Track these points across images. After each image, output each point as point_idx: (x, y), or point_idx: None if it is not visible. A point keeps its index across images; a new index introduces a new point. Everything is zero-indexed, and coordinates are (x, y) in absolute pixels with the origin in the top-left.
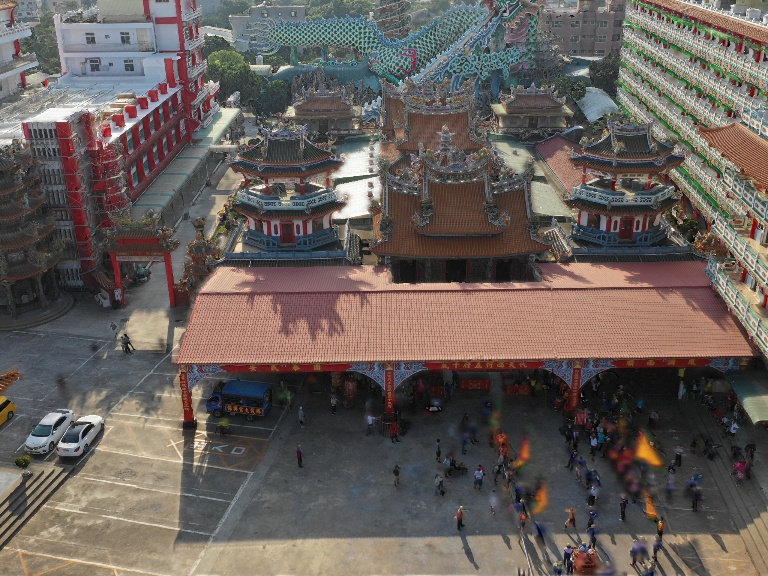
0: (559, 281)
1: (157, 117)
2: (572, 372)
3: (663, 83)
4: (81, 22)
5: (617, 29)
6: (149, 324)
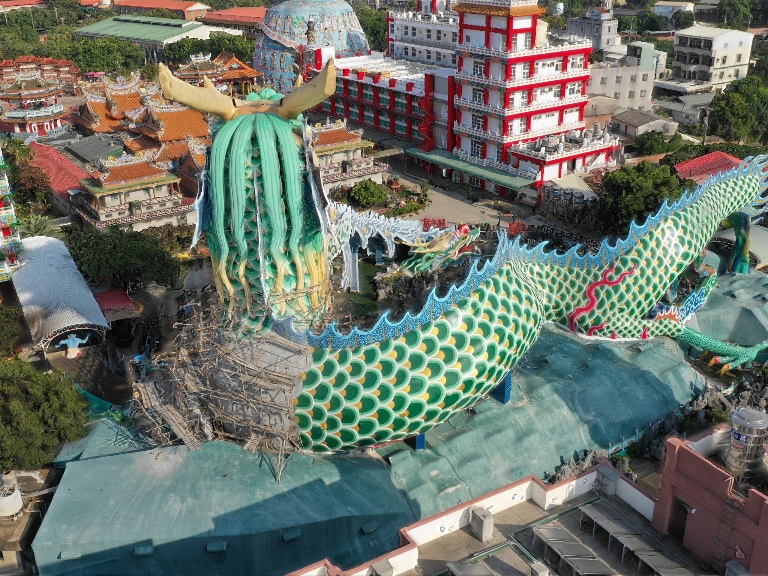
0: None
1: None
2: None
3: None
4: None
5: None
6: None
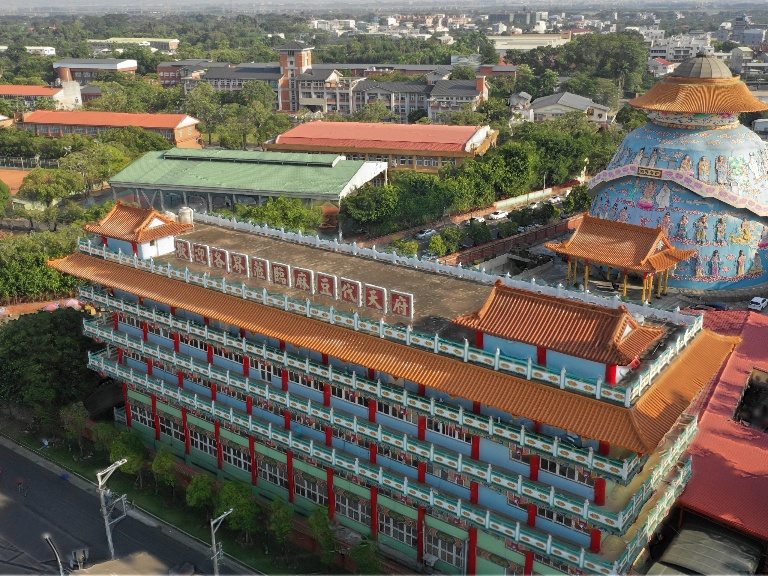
0: (729, 424)
1: None
2: None
3: None
4: None
5: None
6: None
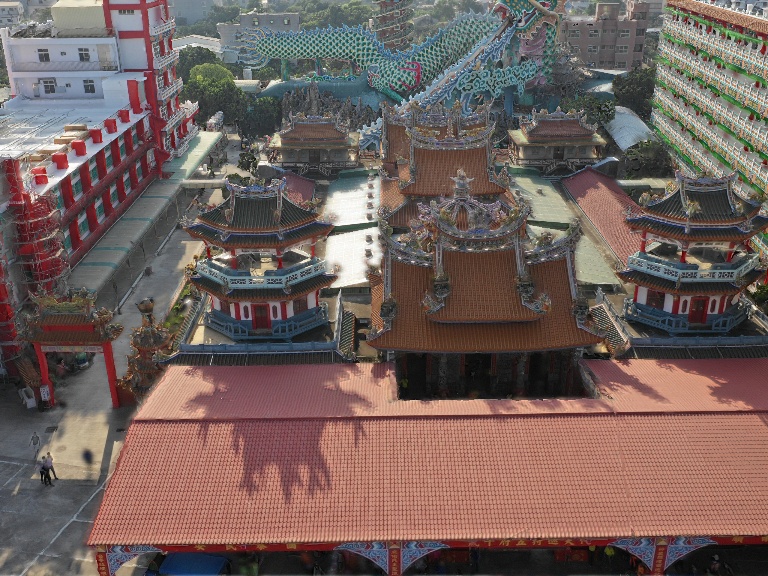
0: (622, 397)
1: (115, 151)
2: (654, 550)
3: (718, 110)
4: (32, 36)
5: (639, 39)
6: (82, 436)
